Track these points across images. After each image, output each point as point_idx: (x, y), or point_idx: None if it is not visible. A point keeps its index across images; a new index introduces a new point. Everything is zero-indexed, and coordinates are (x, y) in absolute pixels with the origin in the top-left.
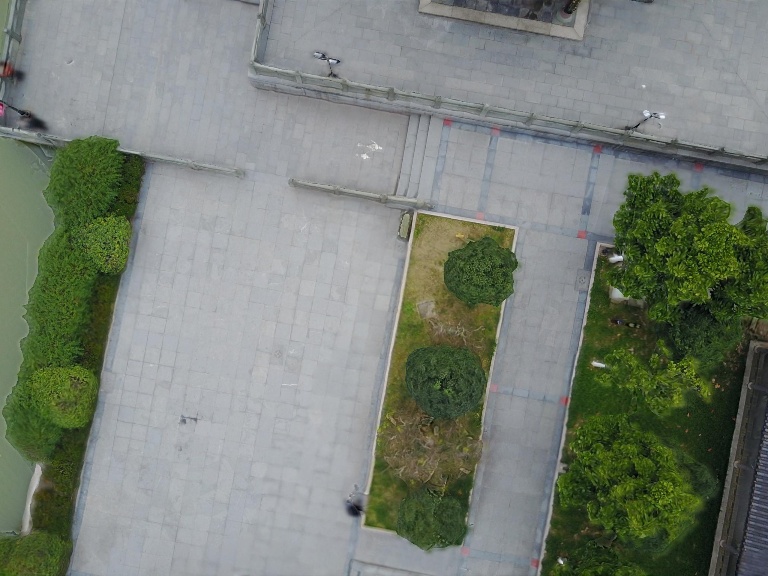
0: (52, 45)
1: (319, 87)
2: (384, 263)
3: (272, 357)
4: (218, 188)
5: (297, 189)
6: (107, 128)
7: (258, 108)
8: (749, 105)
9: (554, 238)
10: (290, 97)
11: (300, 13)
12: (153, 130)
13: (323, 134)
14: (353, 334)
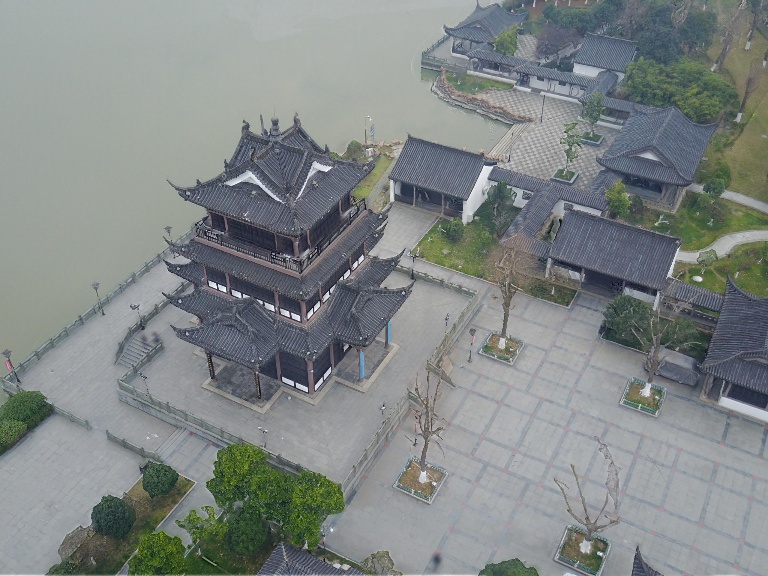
0: (50, 364)
1: (142, 400)
2: (127, 482)
3: (46, 506)
4: (76, 431)
5: (110, 441)
6: (48, 397)
7: (116, 407)
8: (328, 459)
9: None
10: (132, 407)
11: (153, 374)
12: (66, 403)
13: (136, 424)
14: (91, 508)
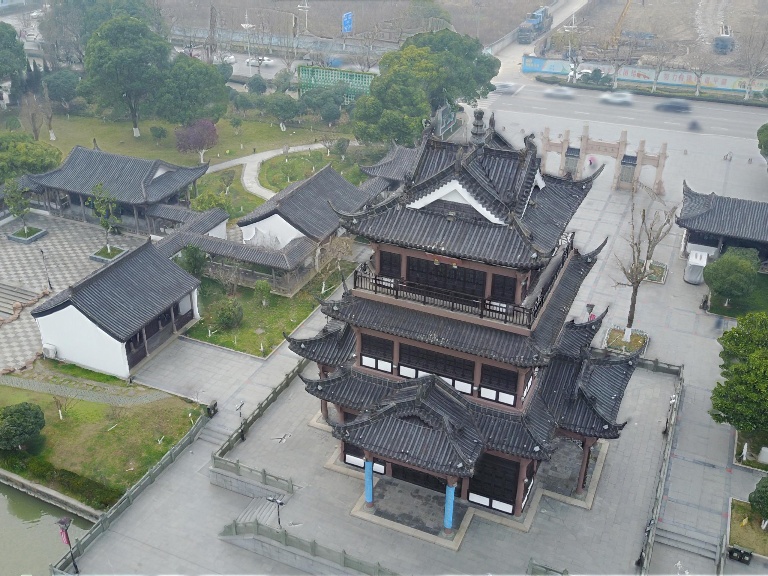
0: None
1: (646, 572)
2: None
3: None
4: None
5: None
6: None
7: None
8: (645, 390)
9: (734, 483)
10: None
11: (590, 573)
12: None
13: None
14: None
